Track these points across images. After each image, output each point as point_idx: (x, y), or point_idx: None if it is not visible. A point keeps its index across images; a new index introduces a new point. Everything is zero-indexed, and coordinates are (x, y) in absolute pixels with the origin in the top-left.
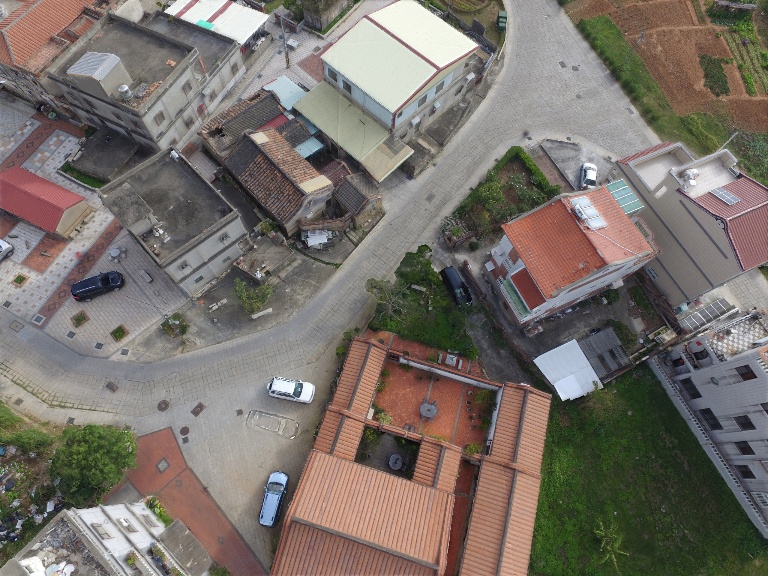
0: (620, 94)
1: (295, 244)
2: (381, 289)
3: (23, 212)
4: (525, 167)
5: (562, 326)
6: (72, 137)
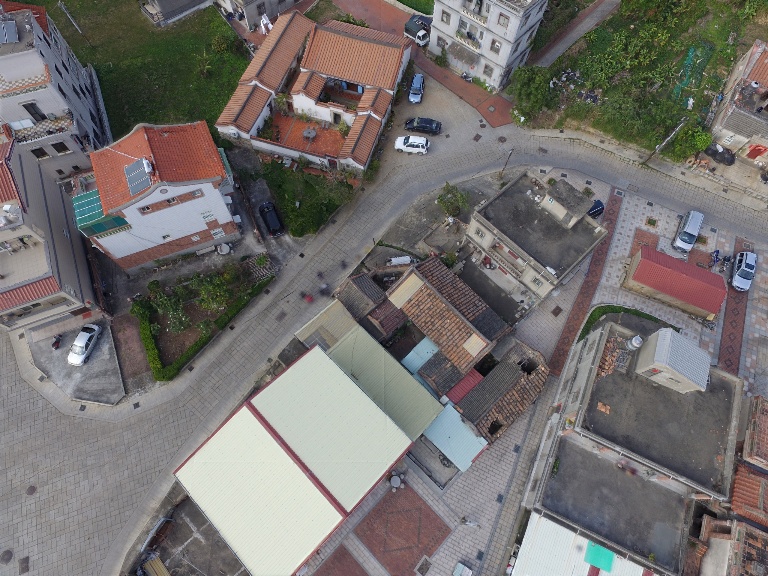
0: None
1: None
2: None
3: (679, 262)
4: None
5: None
6: None
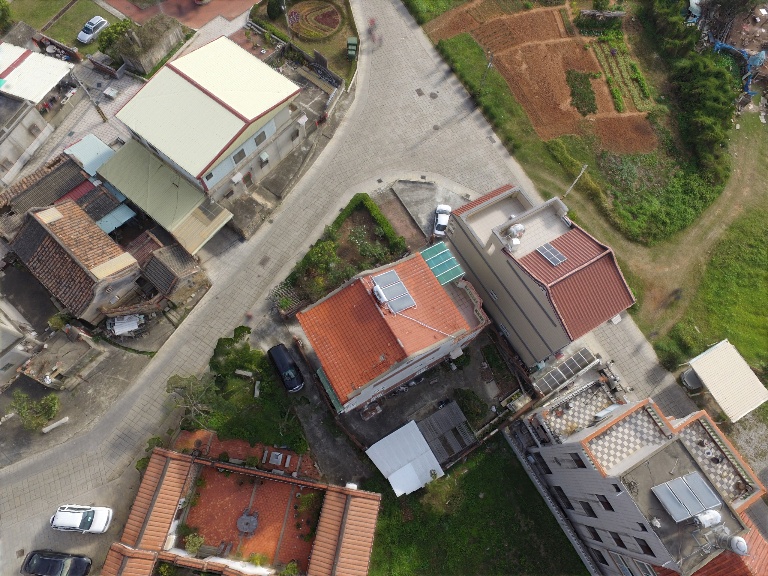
0: (481, 121)
1: (103, 333)
2: (185, 388)
3: None
4: (371, 216)
5: (407, 401)
6: None
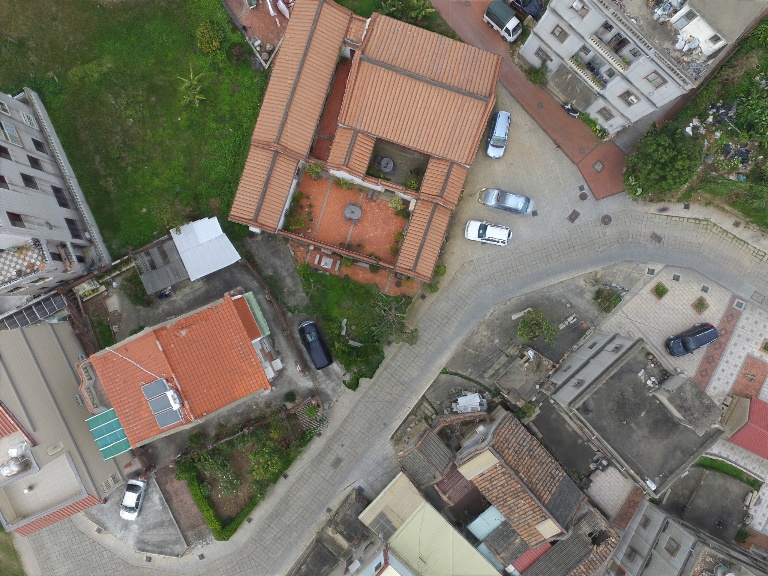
0: None
1: (492, 397)
2: (402, 332)
3: None
4: (214, 510)
5: (201, 302)
6: (759, 530)
